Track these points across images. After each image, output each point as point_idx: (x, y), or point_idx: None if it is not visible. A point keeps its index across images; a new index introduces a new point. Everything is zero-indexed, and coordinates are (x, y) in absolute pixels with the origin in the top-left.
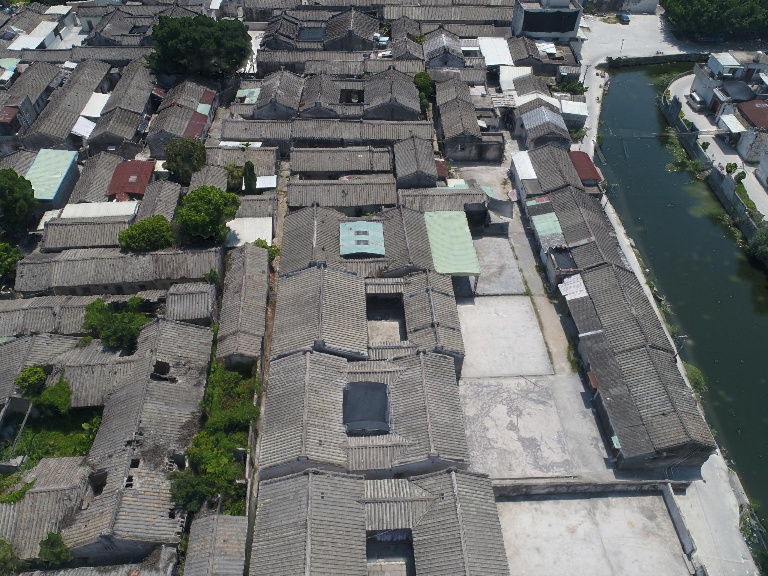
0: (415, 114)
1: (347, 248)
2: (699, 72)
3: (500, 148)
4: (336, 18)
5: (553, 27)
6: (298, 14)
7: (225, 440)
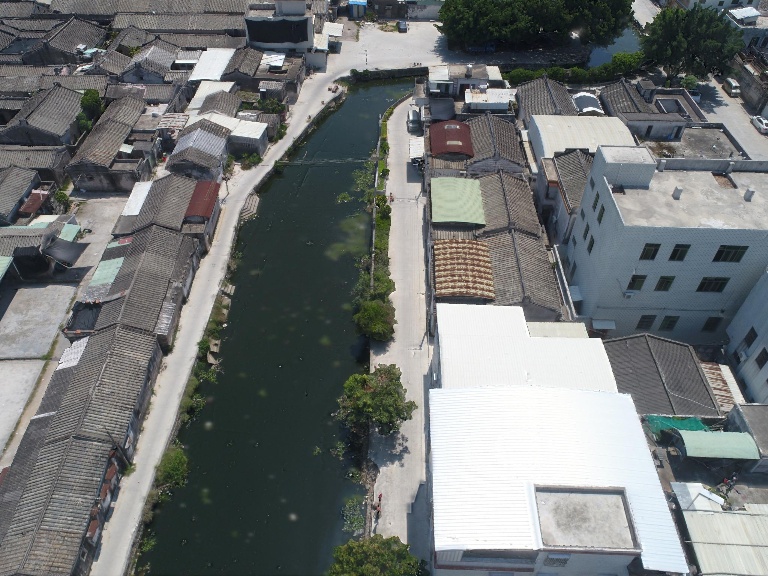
0: (56, 138)
1: None
2: None
3: (133, 177)
4: (57, 28)
5: (285, 37)
6: (25, 23)
7: None
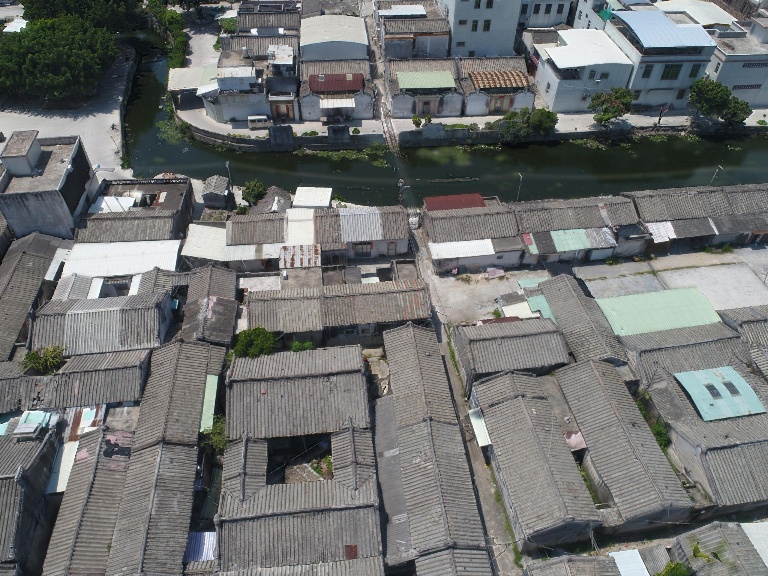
0: None
1: (752, 404)
2: (235, 98)
3: None
4: None
5: None
6: None
7: None
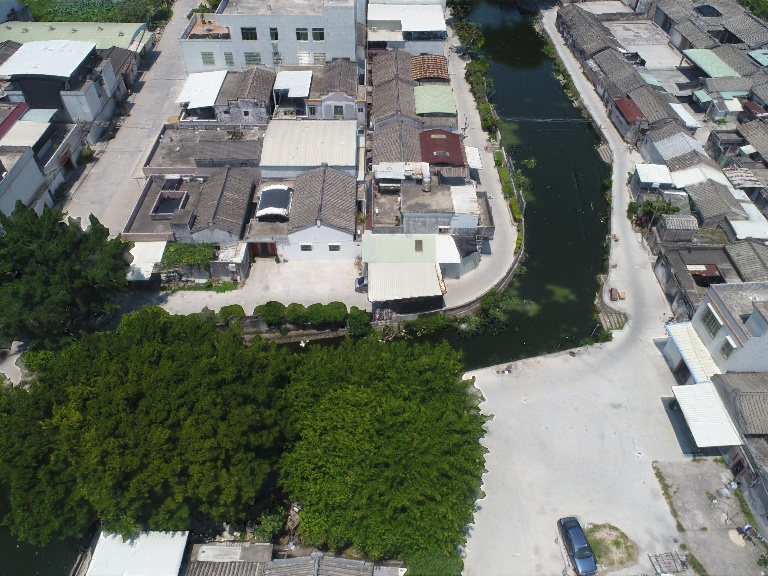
0: None
1: None
2: None
3: None
4: None
5: None
6: None
7: (756, 7)
